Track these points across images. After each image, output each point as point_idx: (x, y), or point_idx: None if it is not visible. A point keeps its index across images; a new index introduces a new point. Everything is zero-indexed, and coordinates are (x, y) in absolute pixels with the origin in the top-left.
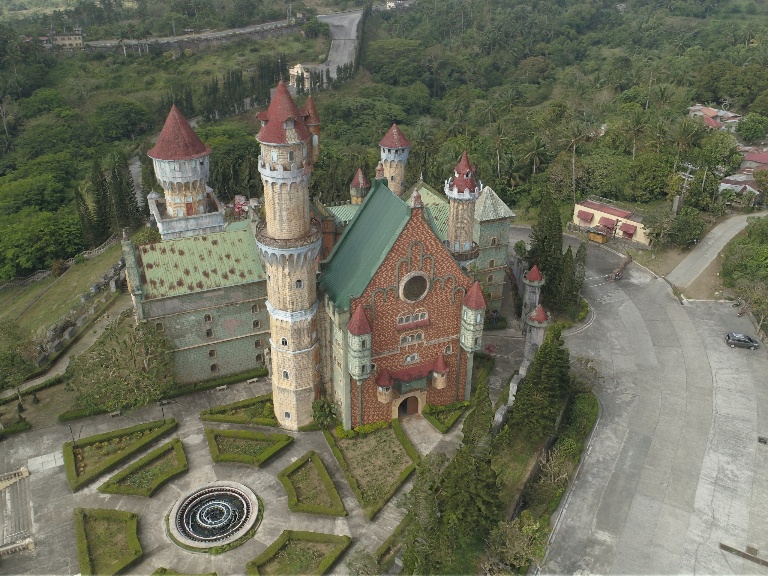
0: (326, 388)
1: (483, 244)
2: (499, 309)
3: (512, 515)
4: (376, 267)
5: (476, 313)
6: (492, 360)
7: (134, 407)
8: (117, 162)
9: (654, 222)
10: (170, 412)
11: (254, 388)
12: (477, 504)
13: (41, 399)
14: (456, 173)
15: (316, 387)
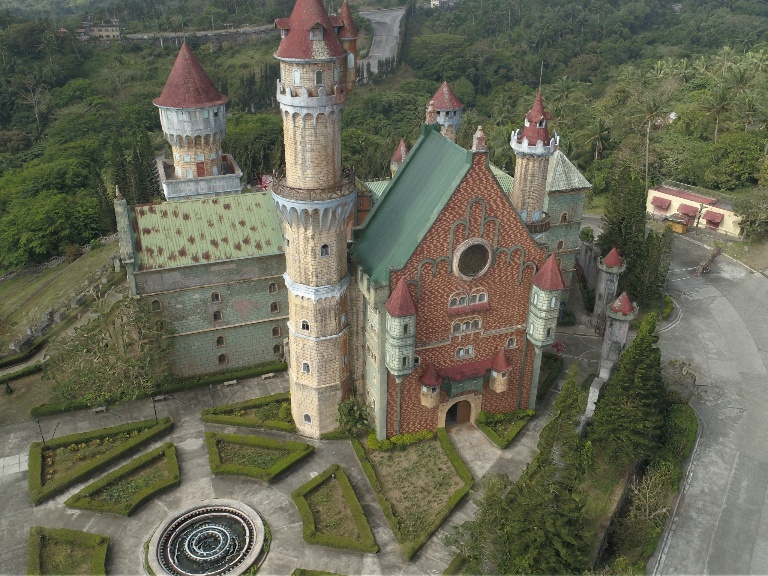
0: (356, 387)
1: (551, 220)
2: (566, 301)
3: (595, 560)
4: (424, 230)
5: (550, 296)
6: (560, 361)
7: (120, 402)
8: (139, 141)
9: (748, 207)
10: (166, 410)
11: (269, 385)
12: (555, 546)
13: (15, 389)
14: (526, 121)
15: (344, 384)
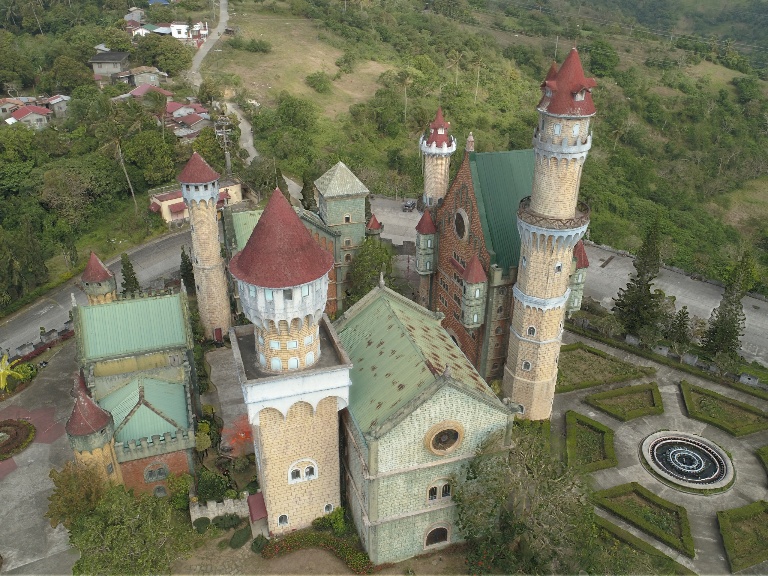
0: None
1: None
2: None
3: None
4: None
5: None
6: None
7: None
8: None
9: None
10: None
11: None
12: None
13: None
14: (441, 131)
15: None
